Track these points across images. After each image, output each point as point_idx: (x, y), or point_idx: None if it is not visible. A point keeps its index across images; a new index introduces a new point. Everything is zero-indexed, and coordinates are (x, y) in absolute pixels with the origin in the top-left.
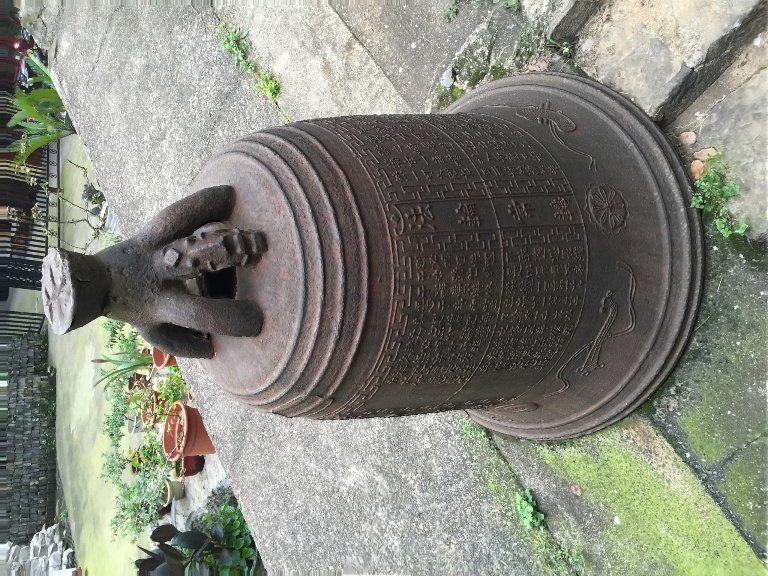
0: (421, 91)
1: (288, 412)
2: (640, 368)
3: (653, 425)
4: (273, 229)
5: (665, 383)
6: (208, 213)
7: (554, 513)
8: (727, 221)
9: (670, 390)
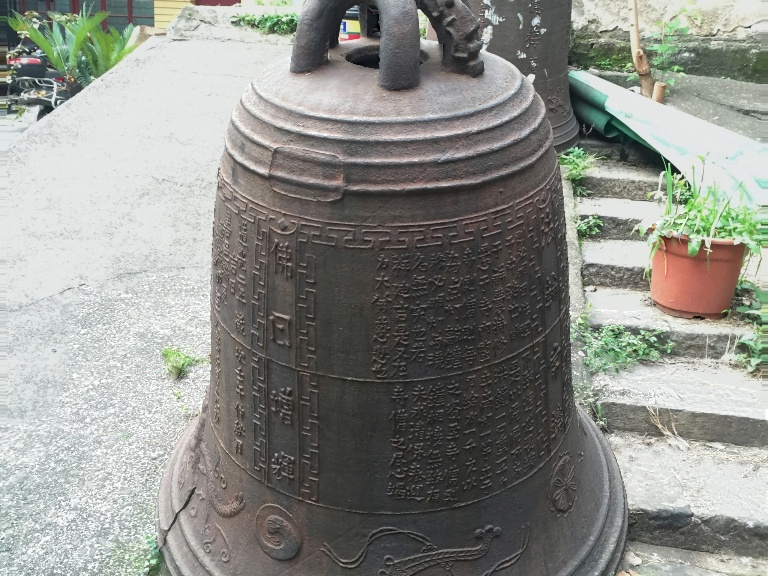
0: None
1: (283, 166)
2: None
3: None
4: (492, 80)
5: None
6: None
7: None
8: None
9: None
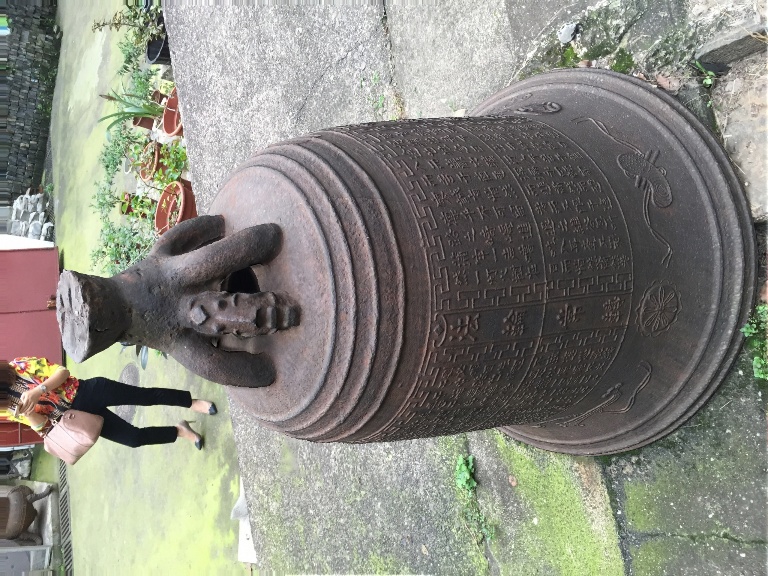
0: (532, 25)
1: None
2: (615, 437)
3: (603, 474)
4: (311, 308)
5: (631, 451)
6: (248, 263)
7: (486, 486)
8: (766, 358)
9: (632, 458)
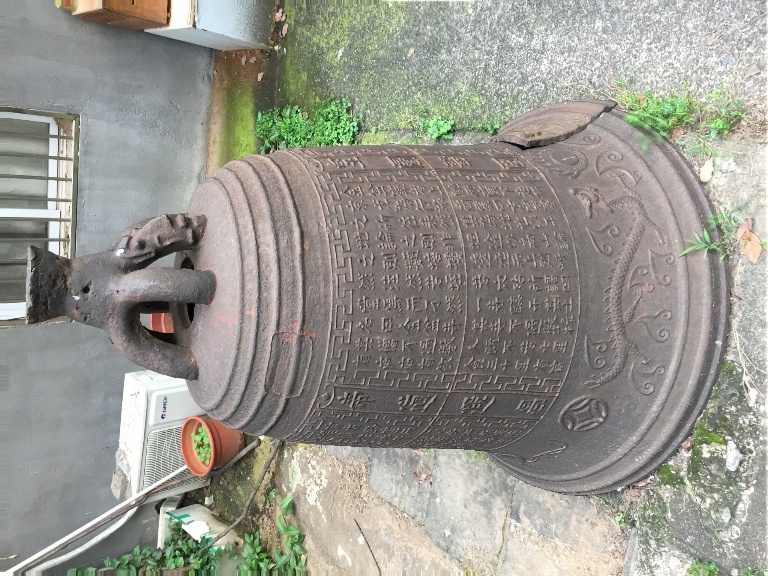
0: None
1: None
2: None
3: None
4: None
5: None
6: None
7: None
8: None
9: None
